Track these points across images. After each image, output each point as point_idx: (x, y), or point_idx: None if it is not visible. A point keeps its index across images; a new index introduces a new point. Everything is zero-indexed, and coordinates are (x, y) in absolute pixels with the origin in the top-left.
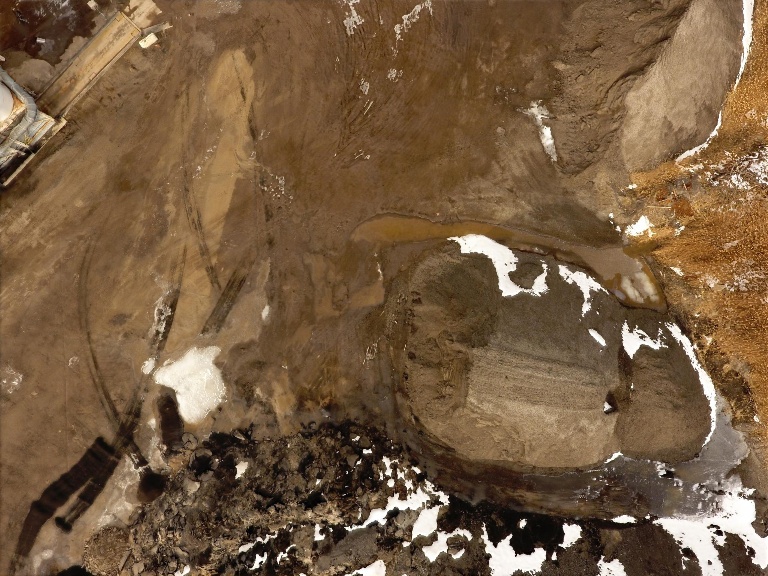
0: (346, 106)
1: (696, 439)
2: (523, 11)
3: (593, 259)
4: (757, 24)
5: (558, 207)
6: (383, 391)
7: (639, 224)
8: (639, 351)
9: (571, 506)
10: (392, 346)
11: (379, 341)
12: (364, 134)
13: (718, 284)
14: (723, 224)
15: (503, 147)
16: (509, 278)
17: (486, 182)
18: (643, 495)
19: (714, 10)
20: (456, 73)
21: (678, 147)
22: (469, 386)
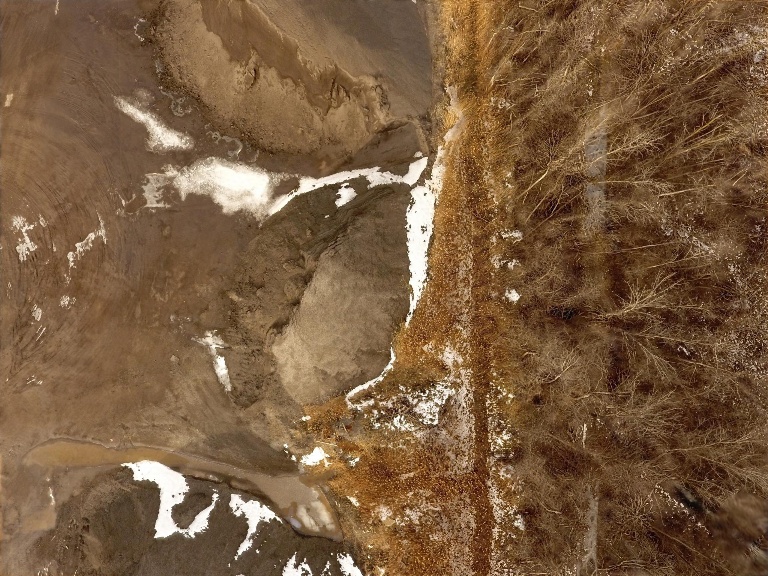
0: (18, 332)
1: None
2: (198, 241)
3: (269, 487)
4: (431, 261)
5: (232, 436)
6: None
7: (314, 454)
8: None
9: None
10: (62, 571)
11: (50, 566)
12: (36, 360)
13: (390, 518)
14: (395, 458)
15: (177, 376)
16: (170, 514)
17: (159, 410)
18: None
19: (346, 275)
20: (129, 302)
21: (345, 385)
22: None
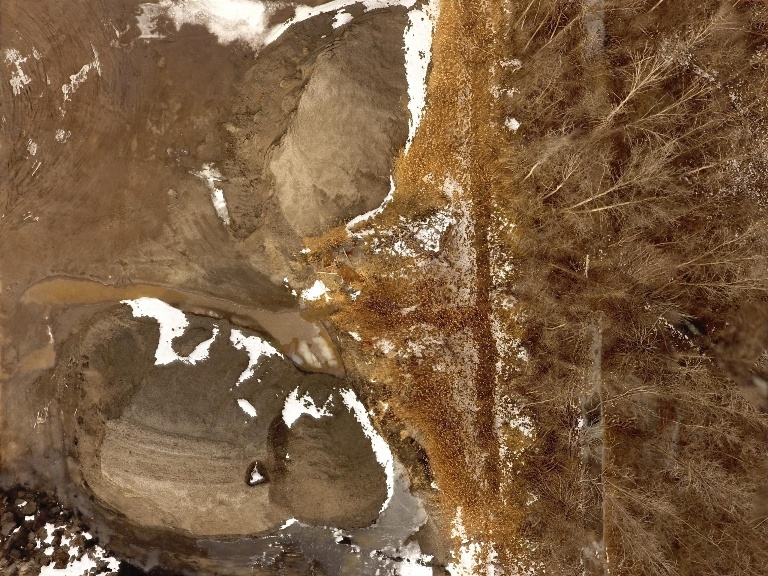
0: (13, 167)
1: (369, 506)
2: (193, 72)
3: (269, 323)
4: (430, 88)
5: (231, 271)
6: (54, 456)
7: (314, 288)
8: (298, 420)
9: (246, 572)
10: (63, 410)
11: (50, 405)
12: (32, 195)
13: (392, 350)
14: (397, 290)
15: (175, 210)
16: (170, 344)
17: (158, 245)
18: (320, 561)
19: (344, 81)
20: (125, 134)
21: (344, 213)
22: (100, 459)
